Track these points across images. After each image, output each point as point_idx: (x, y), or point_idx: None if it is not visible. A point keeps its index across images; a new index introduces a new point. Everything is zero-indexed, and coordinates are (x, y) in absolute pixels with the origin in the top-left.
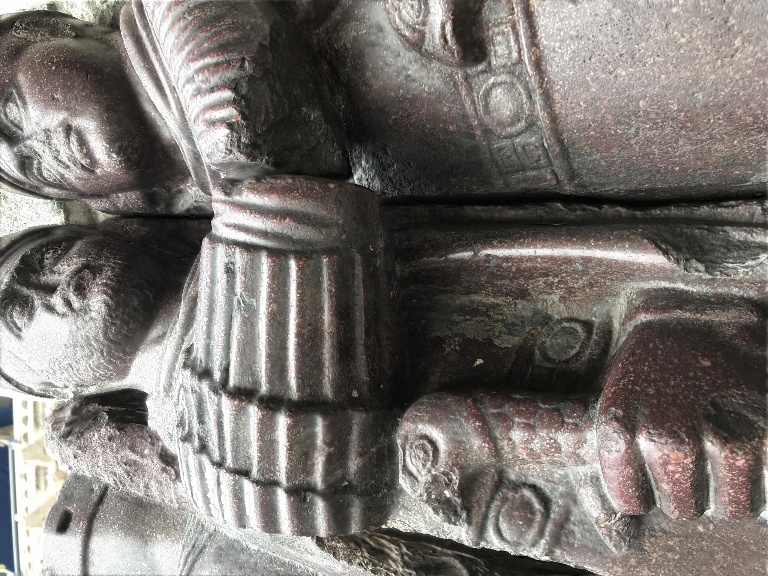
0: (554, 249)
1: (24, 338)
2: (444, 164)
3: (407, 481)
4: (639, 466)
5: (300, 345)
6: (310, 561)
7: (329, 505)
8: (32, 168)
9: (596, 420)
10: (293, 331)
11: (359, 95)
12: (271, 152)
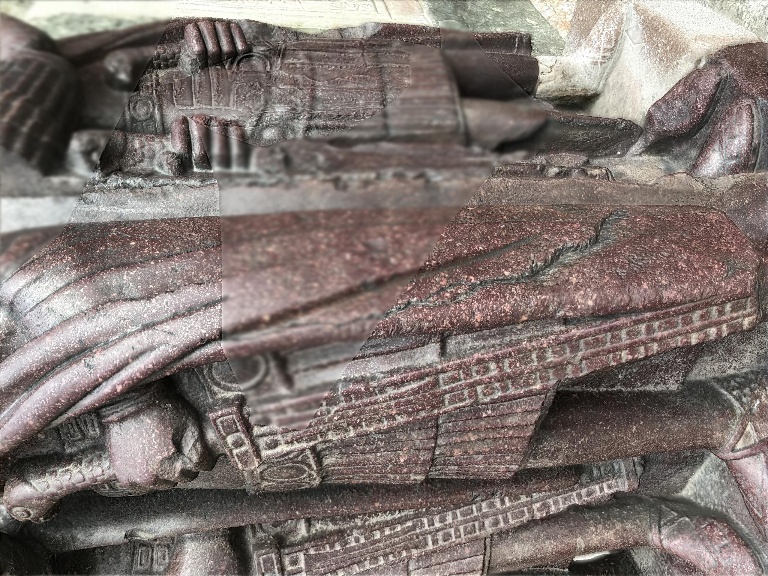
0: None
1: None
2: None
3: None
4: (187, 126)
5: None
6: None
7: None
8: None
9: None
10: None
11: None
12: None
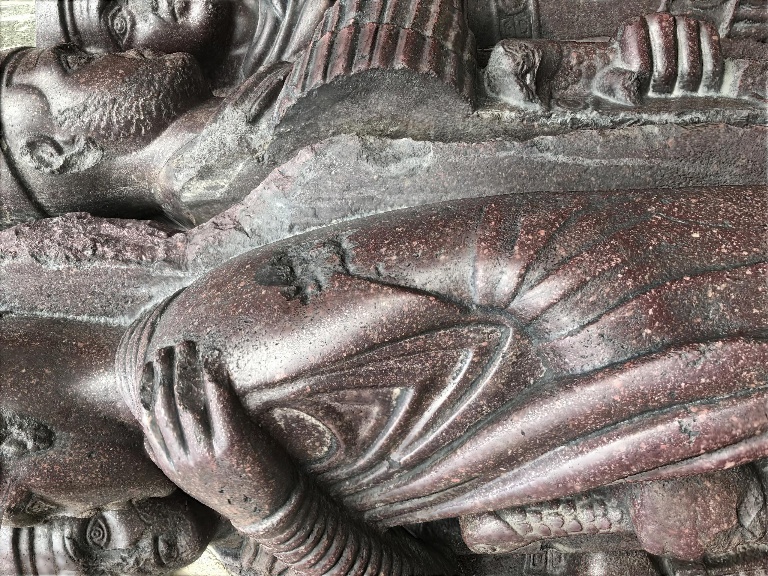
0: None
1: (70, 74)
2: None
3: (509, 55)
4: (647, 31)
5: None
6: (389, 177)
7: (458, 58)
8: (110, 11)
9: (612, 39)
10: None
11: None
12: None
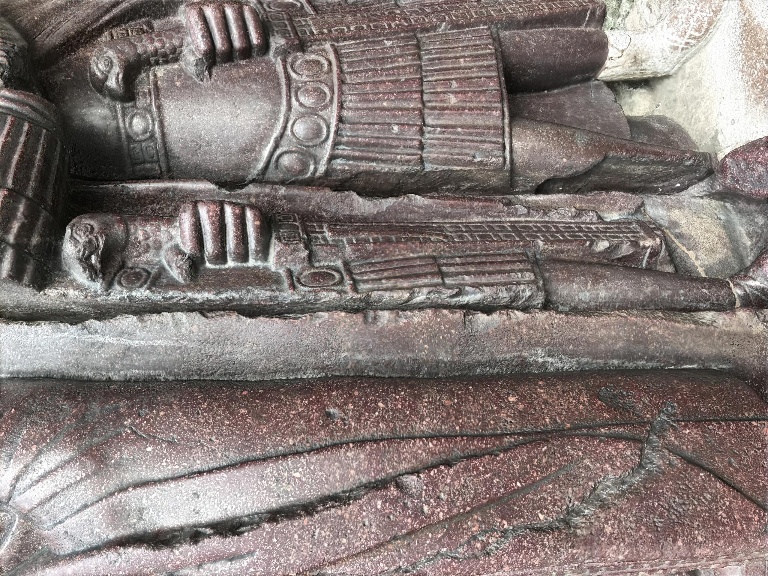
0: (159, 183)
1: None
2: (100, 155)
3: (72, 242)
4: (198, 218)
5: (21, 162)
6: None
7: (16, 252)
8: None
9: None
10: (18, 154)
11: (58, 107)
12: (16, 89)
